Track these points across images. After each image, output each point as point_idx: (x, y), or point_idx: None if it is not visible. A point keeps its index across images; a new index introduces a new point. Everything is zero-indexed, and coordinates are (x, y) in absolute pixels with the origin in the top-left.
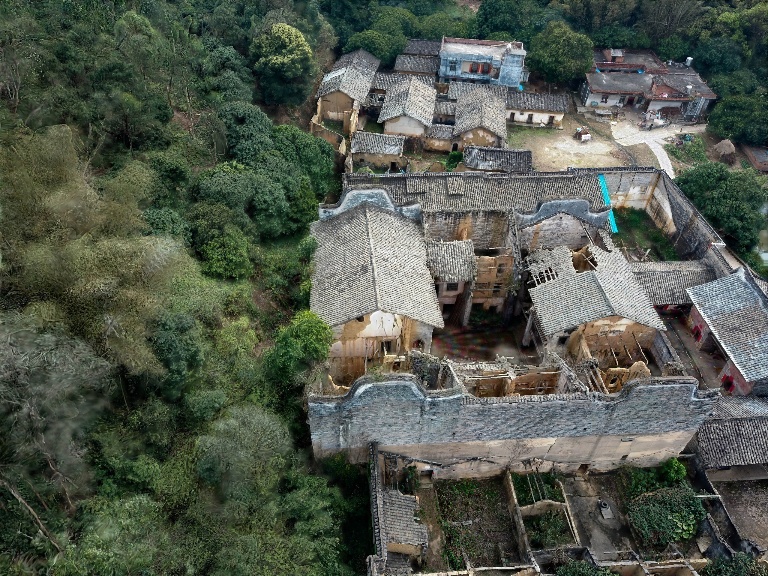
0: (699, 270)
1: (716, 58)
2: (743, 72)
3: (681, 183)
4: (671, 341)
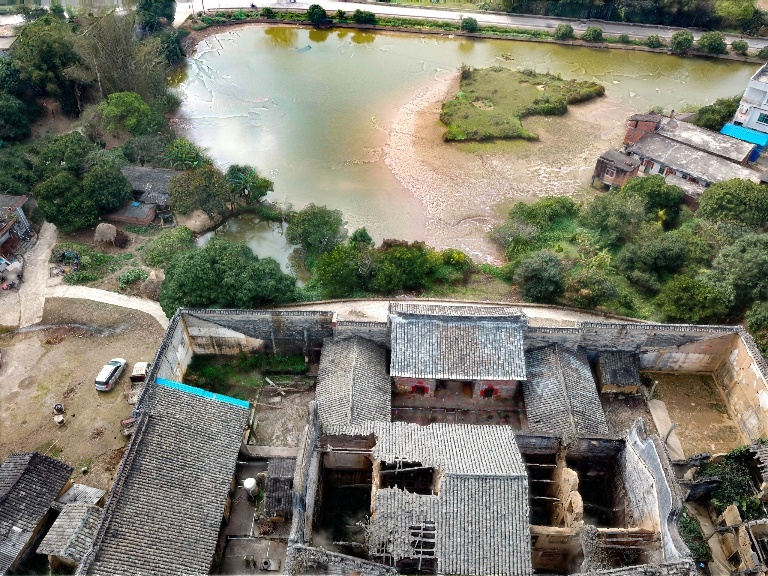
0: (356, 350)
1: None
2: (1, 155)
3: (184, 300)
4: (415, 417)
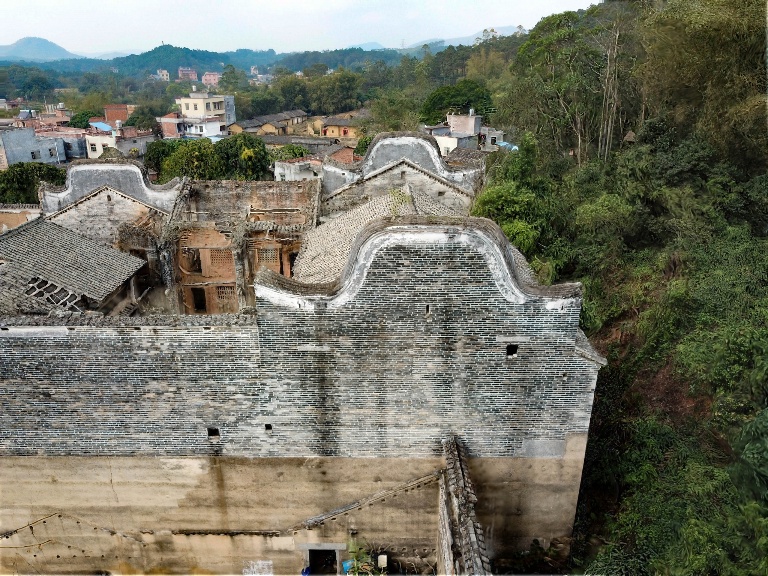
0: None
1: None
2: None
3: None
4: None
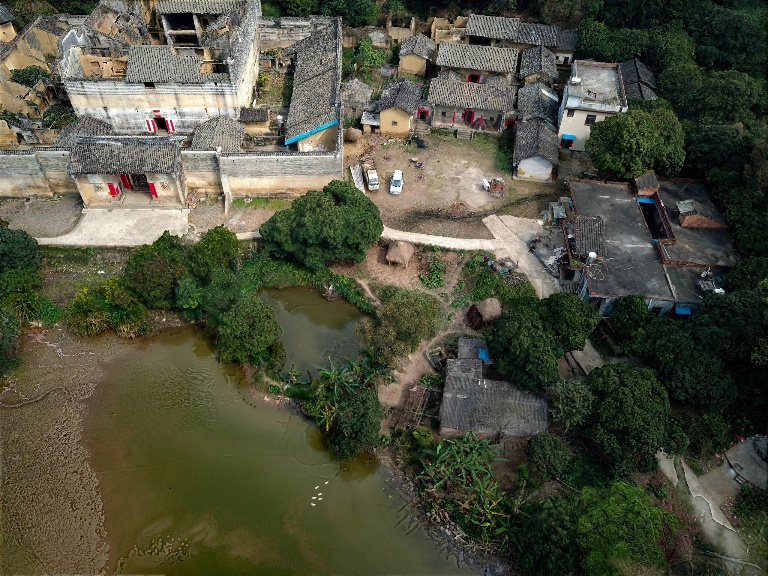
0: None
1: (706, 302)
2: (689, 344)
3: None
4: None
